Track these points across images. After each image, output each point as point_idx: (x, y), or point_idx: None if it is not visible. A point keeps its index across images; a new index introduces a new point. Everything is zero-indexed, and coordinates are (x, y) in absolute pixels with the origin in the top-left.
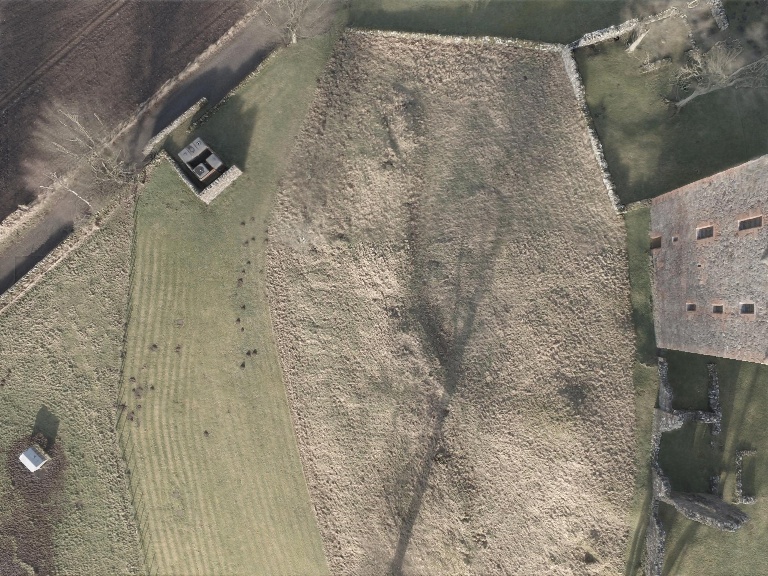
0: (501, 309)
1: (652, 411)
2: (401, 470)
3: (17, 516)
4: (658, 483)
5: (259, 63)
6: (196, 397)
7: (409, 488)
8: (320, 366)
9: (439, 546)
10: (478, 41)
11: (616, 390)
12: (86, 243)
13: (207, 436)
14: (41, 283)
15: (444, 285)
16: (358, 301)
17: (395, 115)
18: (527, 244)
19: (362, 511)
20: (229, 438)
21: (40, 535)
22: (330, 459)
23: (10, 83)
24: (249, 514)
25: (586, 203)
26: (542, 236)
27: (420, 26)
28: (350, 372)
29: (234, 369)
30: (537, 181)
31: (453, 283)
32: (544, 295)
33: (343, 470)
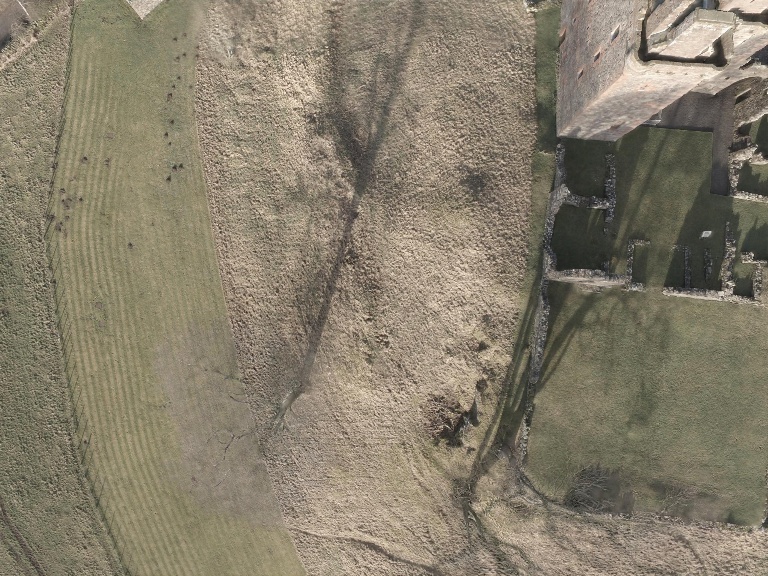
0: (413, 110)
1: (547, 196)
2: (313, 278)
3: None
4: (546, 260)
5: None
6: (122, 209)
7: (319, 295)
8: (242, 179)
9: (345, 350)
10: None
11: (515, 178)
12: (24, 55)
13: (131, 248)
14: None
15: (361, 91)
16: (280, 112)
17: None
18: (439, 42)
19: (275, 322)
20: (152, 251)
21: None
22: (248, 272)
23: None
24: (168, 326)
25: (499, 3)
26: (454, 34)
27: None
28: (270, 184)
29: (160, 183)
30: None
31: (370, 89)
32: (453, 92)
33: (259, 282)
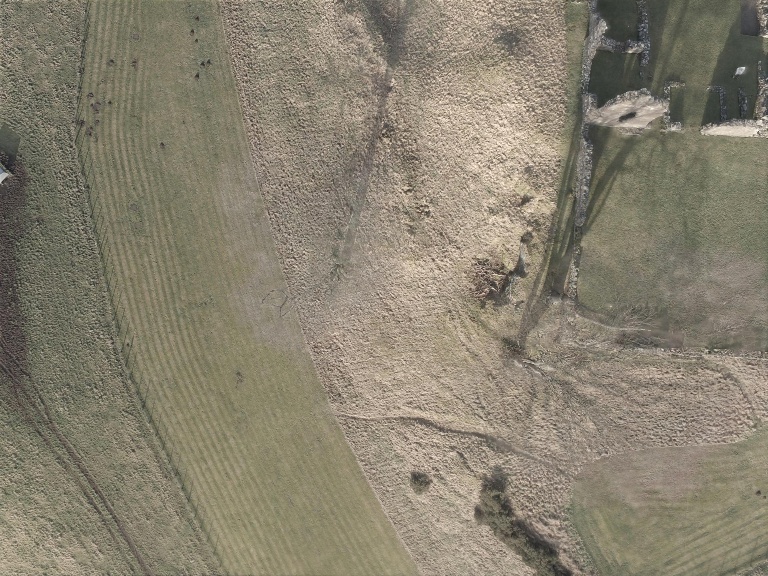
0: None
1: (582, 44)
2: (349, 159)
3: None
4: (586, 101)
5: None
6: (152, 110)
7: (356, 175)
8: (271, 70)
9: (385, 226)
10: None
11: (549, 30)
12: None
13: (163, 148)
14: (1, 2)
15: None
16: None
17: None
18: None
19: (313, 208)
20: (184, 149)
21: (2, 250)
22: (282, 162)
23: None
24: (204, 223)
25: None
26: None
27: None
28: (300, 72)
29: (189, 80)
30: None
31: None
32: None
33: (294, 171)
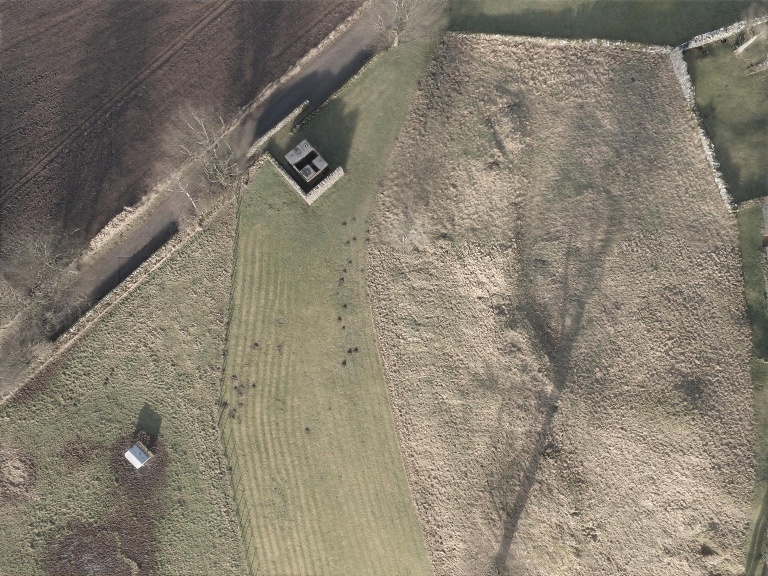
0: (611, 306)
1: None
2: (506, 465)
3: (121, 512)
4: None
5: (360, 66)
6: (297, 394)
7: (515, 483)
8: (422, 363)
9: (546, 540)
10: (584, 44)
11: (733, 385)
12: (189, 244)
13: (308, 433)
14: (144, 283)
15: (551, 283)
16: (462, 299)
17: (500, 116)
18: (639, 242)
19: (465, 506)
20: (330, 435)
21: (143, 531)
22: (432, 455)
23: (114, 87)
24: (350, 510)
25: (697, 202)
26: (654, 234)
27: (523, 29)
28: (453, 369)
29: (335, 367)
30: (648, 180)
31: (560, 281)
32: (657, 292)
33: (445, 466)
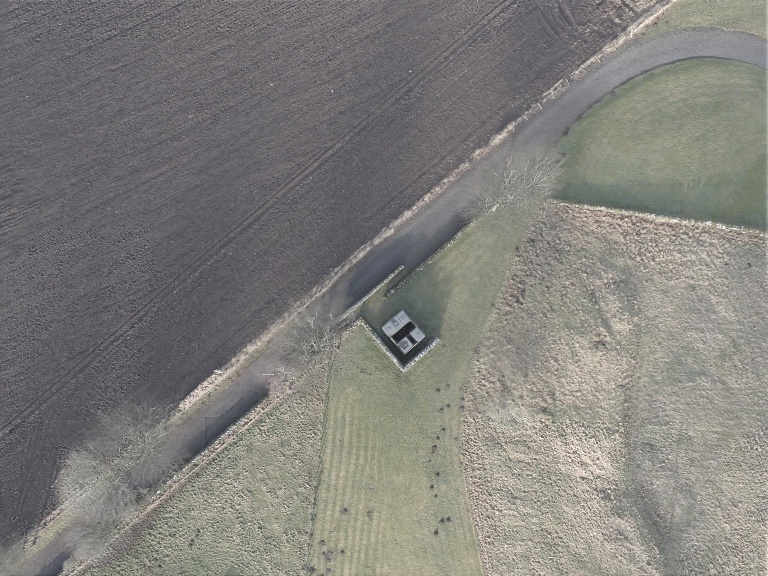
0: (727, 502)
1: None
2: None
3: None
4: None
5: (456, 230)
6: (387, 562)
7: None
8: (518, 538)
9: None
10: (697, 224)
11: None
12: (278, 405)
13: None
14: (232, 444)
15: (660, 470)
16: (562, 477)
17: (605, 292)
18: (759, 440)
19: None
20: None
21: None
22: None
23: (203, 245)
24: None
25: None
26: None
27: (628, 201)
28: (551, 546)
29: (427, 535)
30: (767, 375)
31: (670, 469)
32: None
33: None
